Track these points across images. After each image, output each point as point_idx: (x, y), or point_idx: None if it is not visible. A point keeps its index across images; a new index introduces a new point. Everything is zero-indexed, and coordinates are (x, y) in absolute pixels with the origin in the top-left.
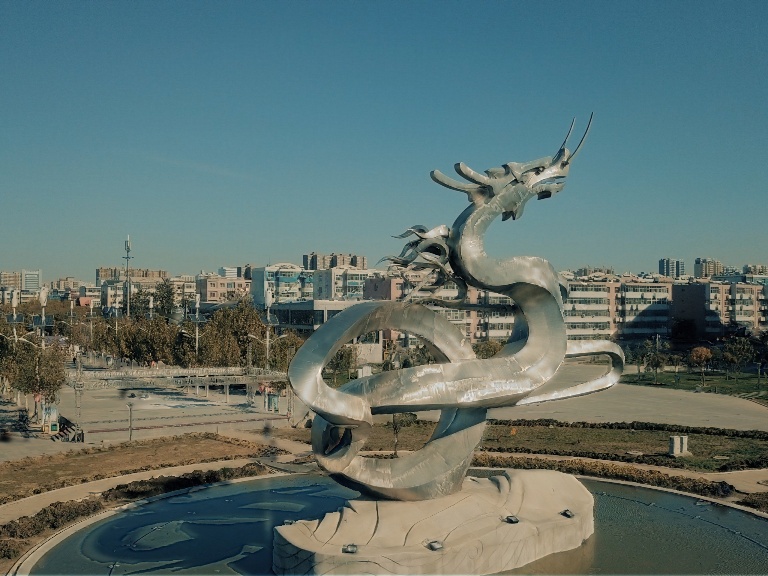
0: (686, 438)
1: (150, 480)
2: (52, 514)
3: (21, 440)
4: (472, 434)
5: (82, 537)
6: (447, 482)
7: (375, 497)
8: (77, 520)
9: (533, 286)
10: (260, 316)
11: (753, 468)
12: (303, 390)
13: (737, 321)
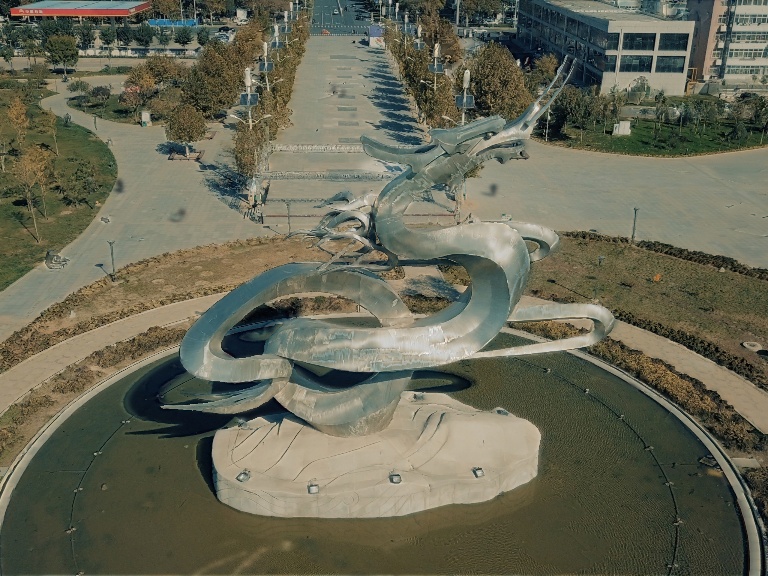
0: None
1: None
2: (138, 343)
3: (223, 211)
4: (395, 386)
5: (141, 375)
6: (361, 425)
7: (305, 421)
8: (155, 351)
9: (474, 256)
10: (456, 97)
11: None
12: (189, 360)
13: None
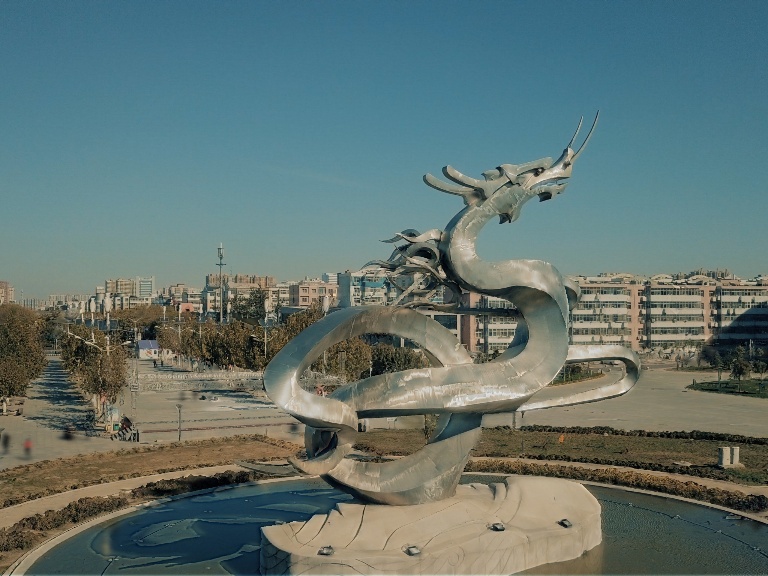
0: (737, 449)
1: (179, 479)
2: (76, 509)
3: (83, 438)
4: (465, 440)
5: (97, 531)
6: (437, 487)
7: (365, 501)
8: (99, 515)
9: (532, 290)
10: None
11: None
12: (276, 393)
13: None
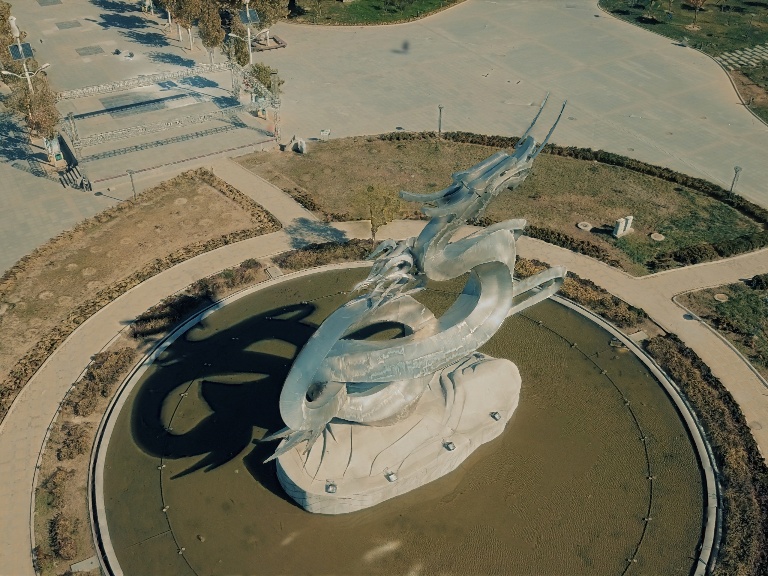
0: (631, 218)
1: (167, 309)
2: (99, 379)
3: (33, 183)
4: None
5: (129, 412)
6: (405, 412)
7: (350, 421)
8: (120, 381)
9: (488, 262)
10: (239, 13)
11: (678, 262)
12: (292, 421)
13: None
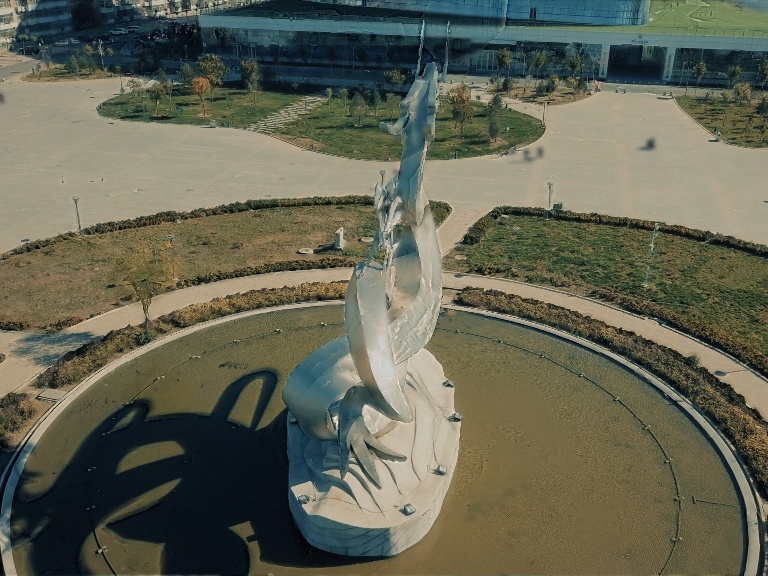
0: None
1: None
2: None
3: None
4: None
5: None
6: None
7: None
8: None
9: None
10: None
11: None
12: (402, 411)
13: (143, 7)
